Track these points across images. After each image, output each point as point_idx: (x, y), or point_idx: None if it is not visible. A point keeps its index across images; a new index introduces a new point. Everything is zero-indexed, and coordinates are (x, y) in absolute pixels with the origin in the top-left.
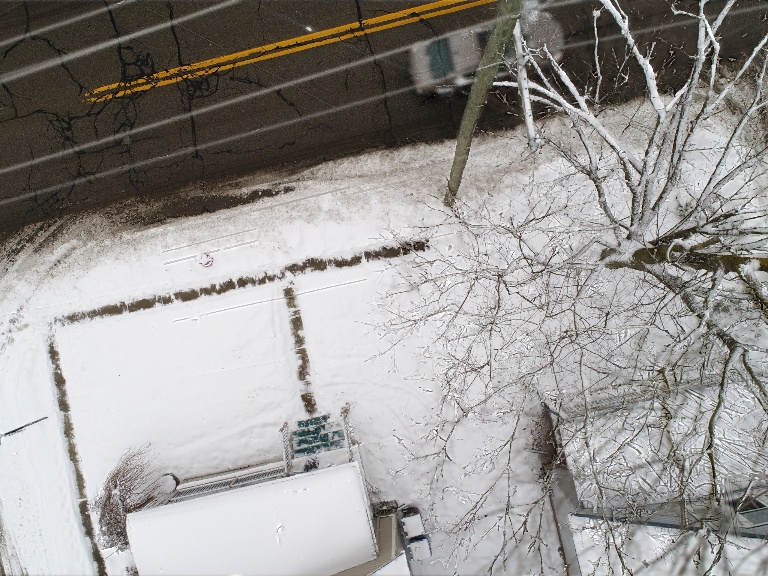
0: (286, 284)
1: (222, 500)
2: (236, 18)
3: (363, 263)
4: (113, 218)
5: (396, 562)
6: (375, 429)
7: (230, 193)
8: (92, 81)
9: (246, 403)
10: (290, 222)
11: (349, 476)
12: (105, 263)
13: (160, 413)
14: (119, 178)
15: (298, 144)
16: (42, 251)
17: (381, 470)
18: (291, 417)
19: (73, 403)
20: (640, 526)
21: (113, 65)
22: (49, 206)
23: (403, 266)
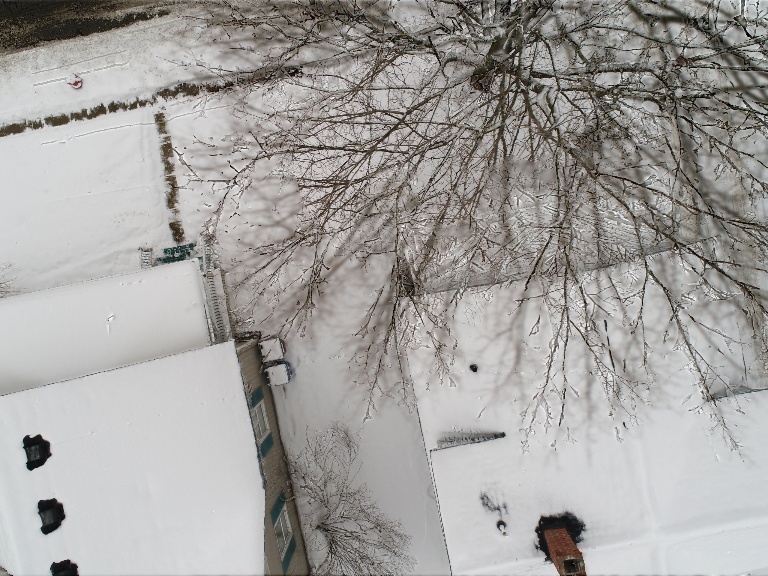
0: (157, 109)
1: (56, 291)
2: None
3: None
4: None
5: (221, 346)
6: (242, 258)
7: (104, 16)
8: None
9: (111, 228)
10: (162, 44)
11: (186, 269)
12: None
13: (25, 238)
14: None
15: None
16: None
17: (246, 300)
18: (157, 244)
19: None
20: (454, 291)
21: None
22: None
23: None
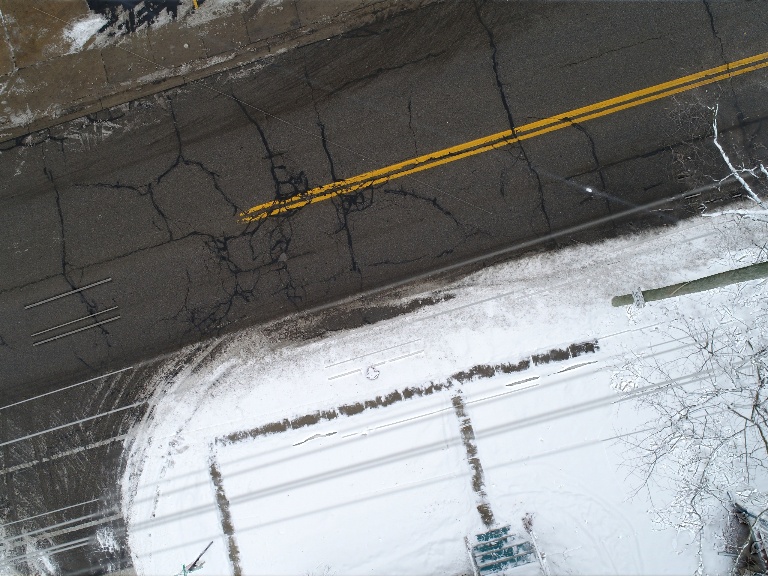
0: (454, 393)
1: None
2: (388, 132)
3: (532, 367)
4: (272, 335)
5: None
6: (558, 539)
7: (390, 303)
8: (246, 201)
9: (423, 519)
10: (455, 330)
11: None
12: (268, 381)
13: (332, 533)
14: (277, 294)
15: (456, 251)
16: (200, 371)
17: None
18: (470, 531)
19: (239, 526)
20: None
21: (267, 184)
22: (206, 326)
23: (575, 369)
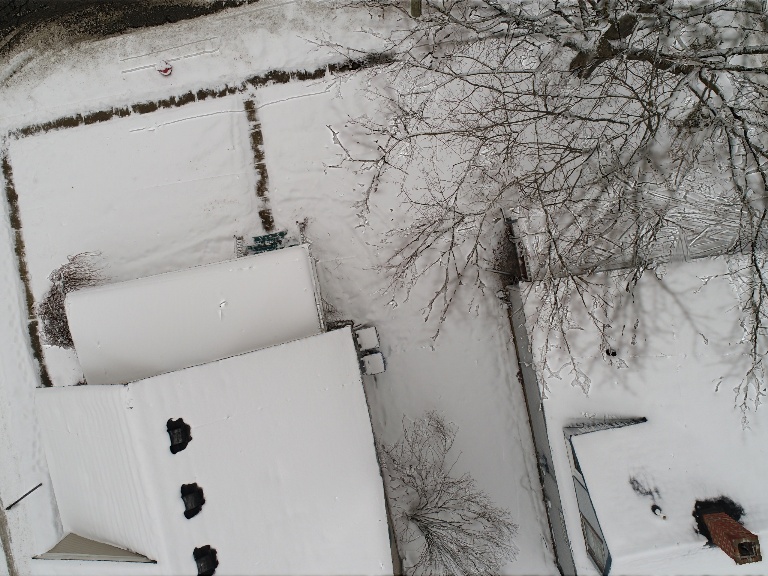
0: (247, 97)
1: (165, 277)
2: None
3: (327, 76)
4: (71, 27)
5: (340, 331)
6: (333, 246)
7: (193, 3)
8: None
9: (201, 216)
10: (253, 31)
11: (297, 255)
12: (61, 71)
13: (113, 227)
14: None
15: None
16: None
17: (338, 288)
18: (247, 232)
19: (25, 218)
20: None
21: None
22: (6, 14)
23: None
